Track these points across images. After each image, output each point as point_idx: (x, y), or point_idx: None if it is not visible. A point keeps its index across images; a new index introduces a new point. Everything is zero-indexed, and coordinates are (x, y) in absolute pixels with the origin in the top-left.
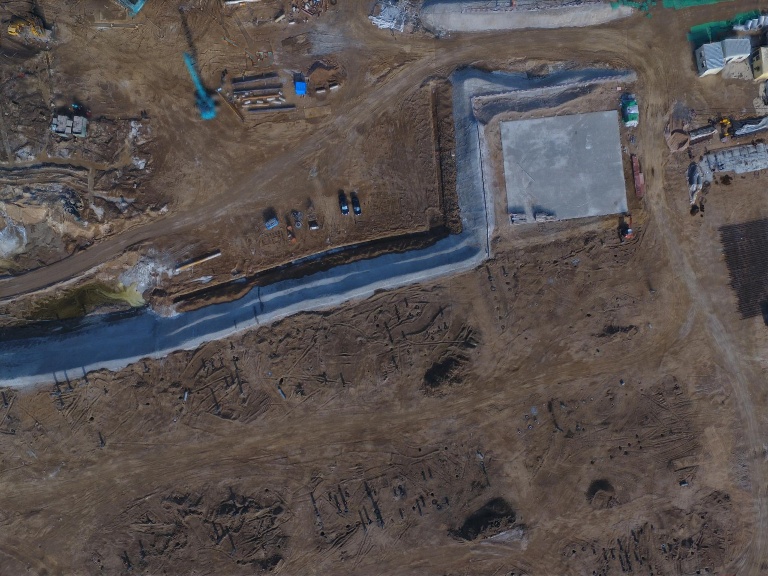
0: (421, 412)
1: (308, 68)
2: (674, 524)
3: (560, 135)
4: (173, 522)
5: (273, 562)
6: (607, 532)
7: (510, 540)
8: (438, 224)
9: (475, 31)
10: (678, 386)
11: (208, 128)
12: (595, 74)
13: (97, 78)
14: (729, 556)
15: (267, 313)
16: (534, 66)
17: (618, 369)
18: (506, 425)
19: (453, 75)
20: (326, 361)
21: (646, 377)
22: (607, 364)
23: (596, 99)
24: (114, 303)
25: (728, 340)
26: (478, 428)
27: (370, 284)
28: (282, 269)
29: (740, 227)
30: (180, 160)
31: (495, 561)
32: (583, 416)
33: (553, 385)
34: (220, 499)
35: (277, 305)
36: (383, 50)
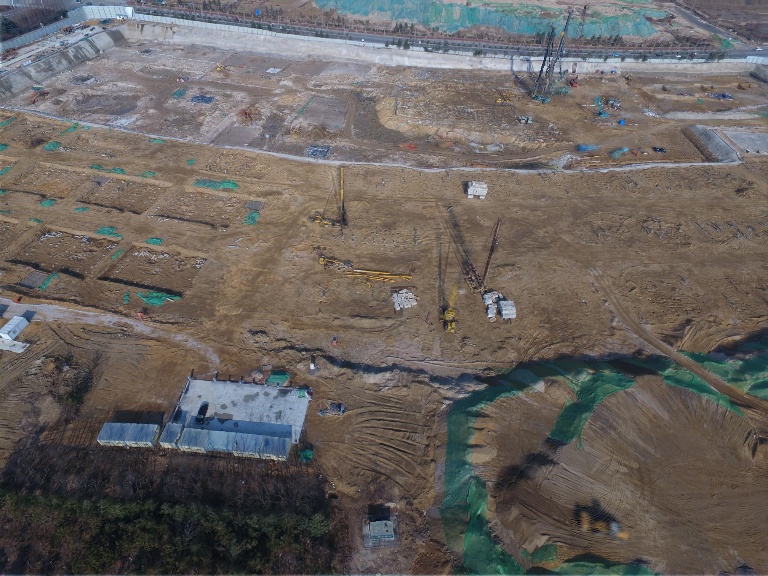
0: None
1: None
2: None
3: (752, 136)
4: None
5: None
6: None
7: None
8: None
9: (690, 119)
10: None
11: (583, 128)
12: None
13: None
14: None
15: None
16: None
17: None
18: None
19: None
20: None
21: None
22: None
23: None
24: None
25: None
26: None
27: (687, 163)
28: None
29: None
30: (574, 133)
31: None
32: None
33: None
34: (642, 218)
35: None
36: None
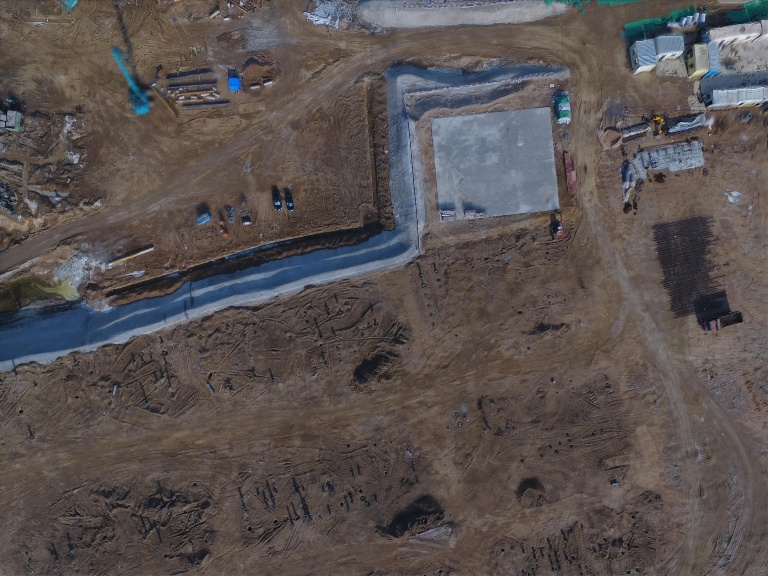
0: (350, 408)
1: (243, 64)
2: (604, 523)
3: (491, 132)
4: (101, 515)
5: (200, 556)
6: (536, 531)
7: (438, 537)
8: (372, 220)
9: (410, 28)
10: (609, 385)
11: (142, 123)
12: (528, 71)
13: (32, 73)
14: (660, 556)
15: (196, 308)
16: (469, 63)
17: (549, 367)
18: (435, 422)
19: (388, 71)
20: (255, 356)
21: (577, 375)
22: (538, 362)
23: (528, 96)
24: (49, 297)
25: (660, 339)
26: (407, 425)
27: (300, 280)
28: (215, 264)
29: (674, 225)
30: (114, 155)
31: (423, 558)
32: (513, 414)
33: (483, 382)
34: (148, 493)
35: (207, 300)
36: (318, 46)
